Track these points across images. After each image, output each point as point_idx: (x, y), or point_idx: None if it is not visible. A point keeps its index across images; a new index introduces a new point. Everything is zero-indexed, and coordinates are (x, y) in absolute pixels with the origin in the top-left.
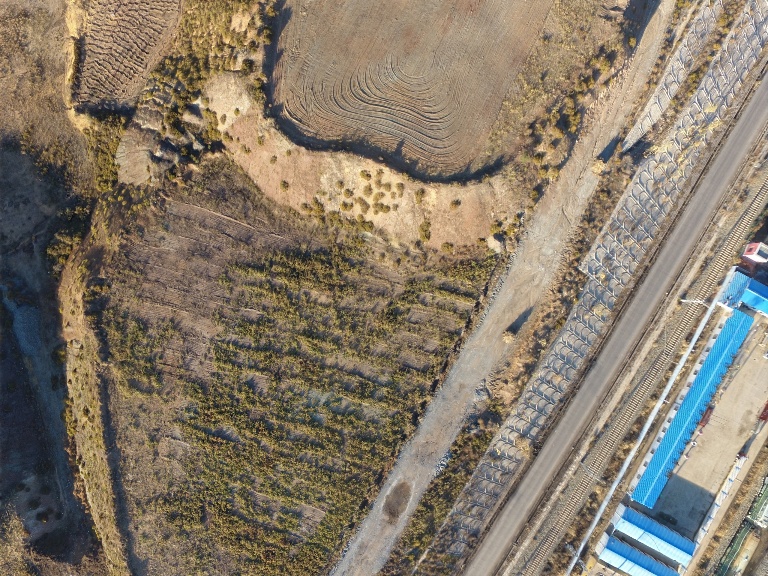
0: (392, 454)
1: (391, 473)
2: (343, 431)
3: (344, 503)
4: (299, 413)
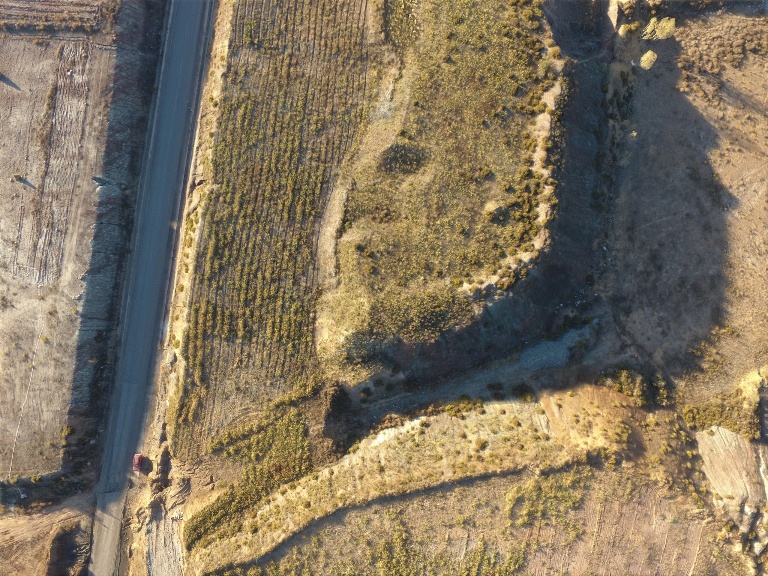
0: None
1: None
2: None
3: None
4: None
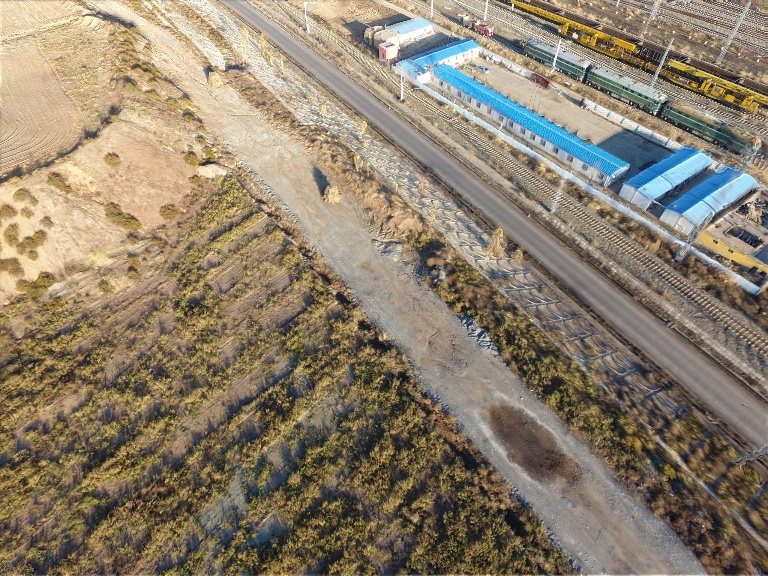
0: (425, 412)
1: (462, 427)
2: (328, 487)
3: (495, 571)
4: (226, 575)
